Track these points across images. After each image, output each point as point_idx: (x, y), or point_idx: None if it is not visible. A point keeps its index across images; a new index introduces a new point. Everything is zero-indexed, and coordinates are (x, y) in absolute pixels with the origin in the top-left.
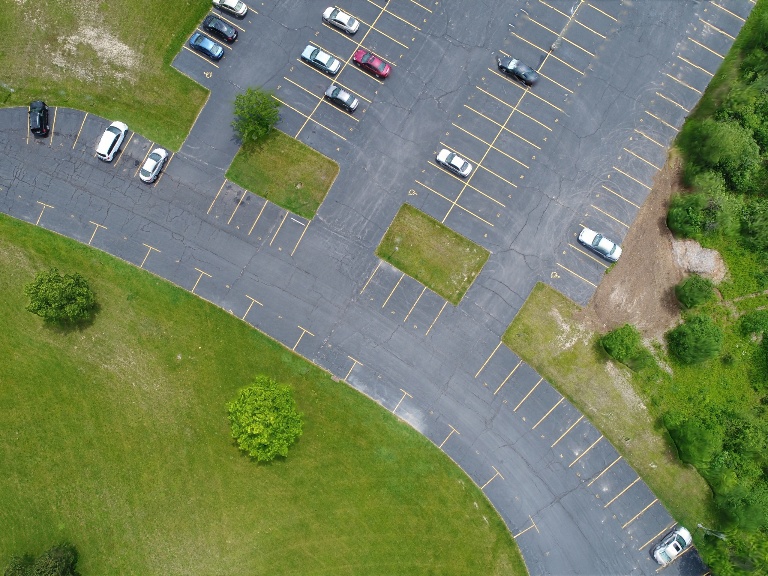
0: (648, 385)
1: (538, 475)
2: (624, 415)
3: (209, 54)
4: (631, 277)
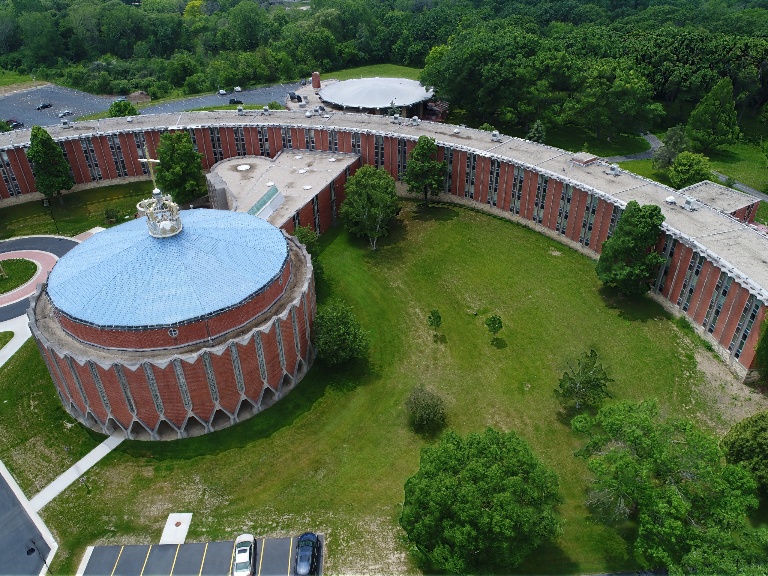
0: None
1: None
2: None
3: None
4: None
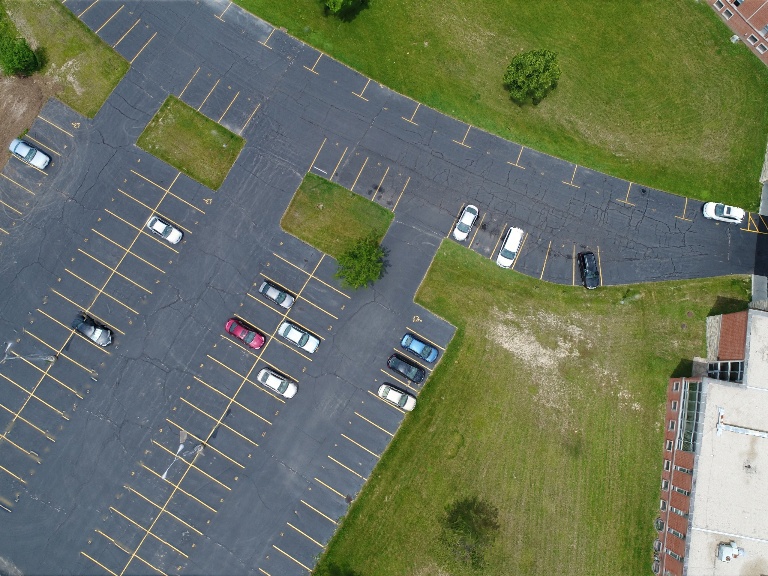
0: (2, 31)
1: None
2: (27, 5)
3: (415, 338)
4: (5, 127)
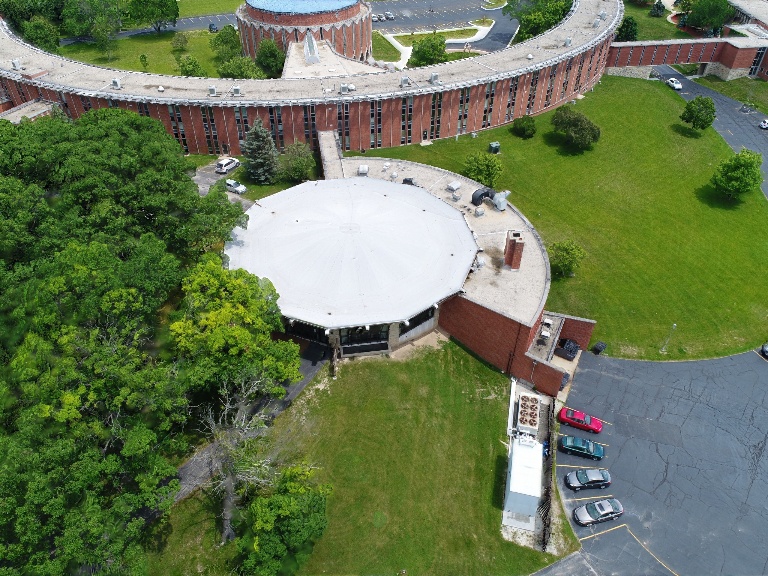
0: None
1: None
2: None
3: None
4: None
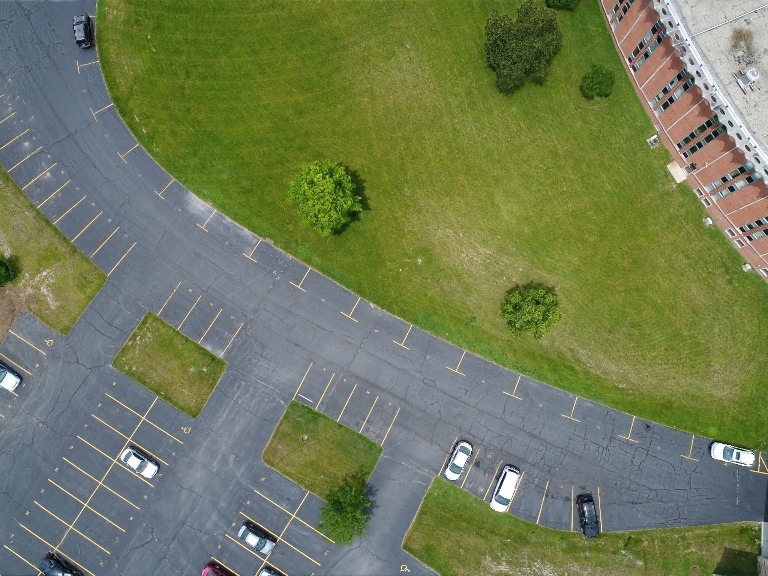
0: None
1: (86, 156)
2: (0, 208)
3: None
4: None
